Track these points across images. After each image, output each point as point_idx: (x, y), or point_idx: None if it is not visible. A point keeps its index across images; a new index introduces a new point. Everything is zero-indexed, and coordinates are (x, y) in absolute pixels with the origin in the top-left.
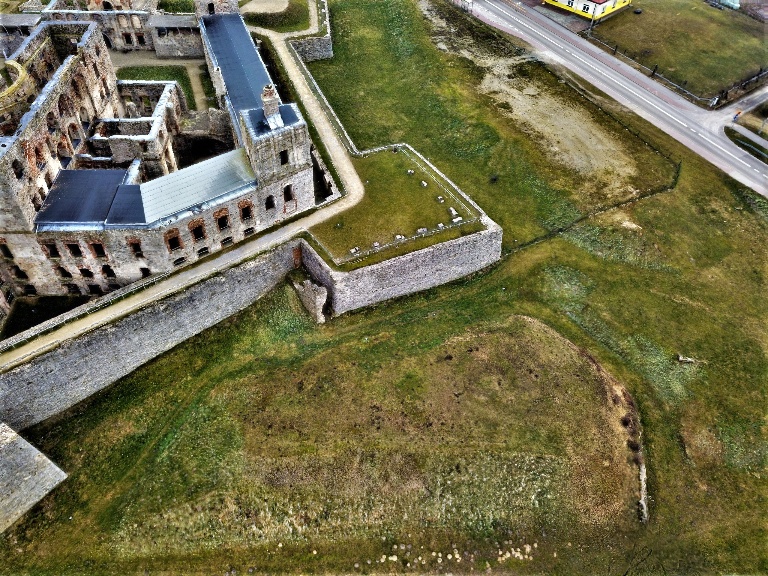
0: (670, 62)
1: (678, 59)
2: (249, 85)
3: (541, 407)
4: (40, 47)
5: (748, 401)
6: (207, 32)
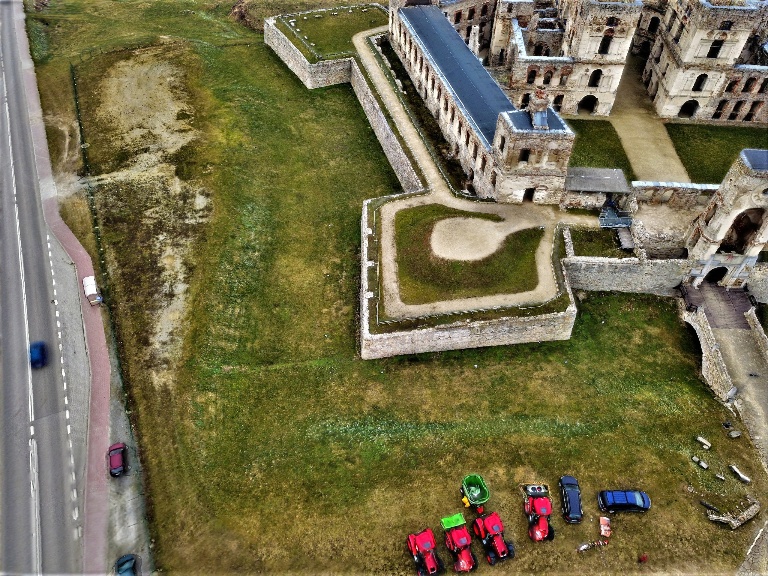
0: None
1: None
2: (448, 47)
3: (281, 0)
4: (626, 1)
5: (174, 5)
6: None
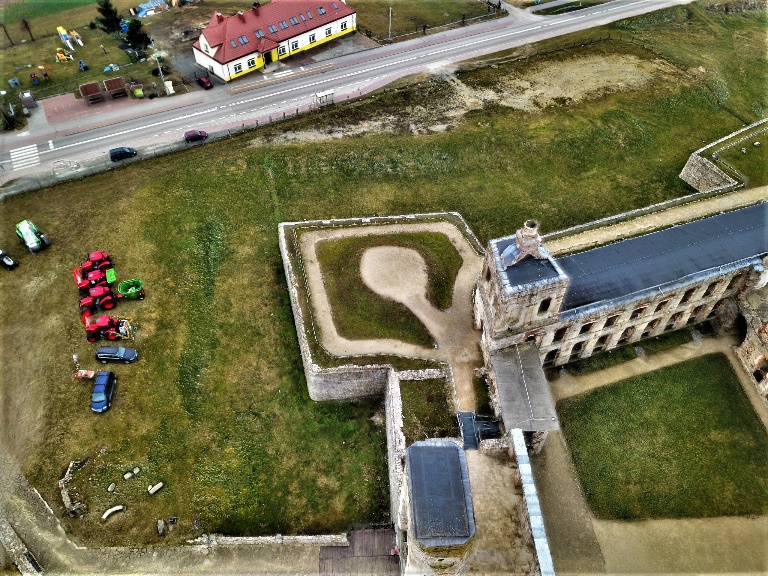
0: (434, 12)
1: (426, 8)
2: (757, 227)
3: None
4: None
5: None
6: (615, 296)
